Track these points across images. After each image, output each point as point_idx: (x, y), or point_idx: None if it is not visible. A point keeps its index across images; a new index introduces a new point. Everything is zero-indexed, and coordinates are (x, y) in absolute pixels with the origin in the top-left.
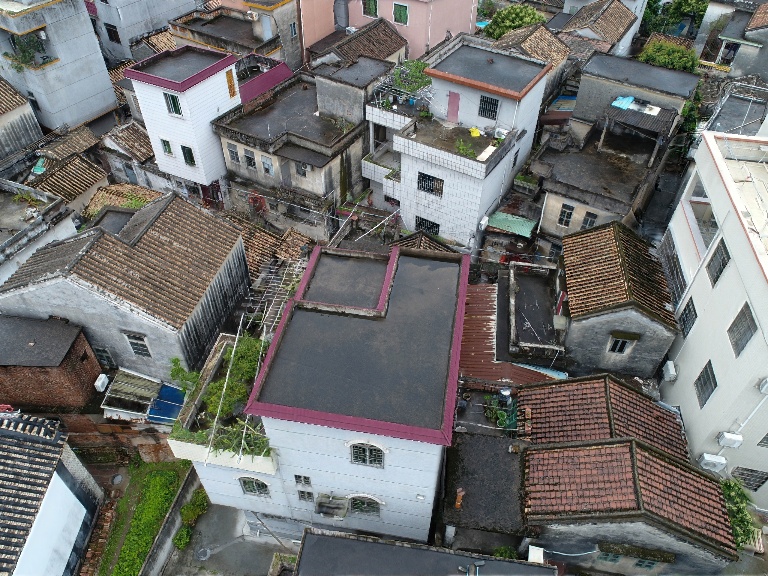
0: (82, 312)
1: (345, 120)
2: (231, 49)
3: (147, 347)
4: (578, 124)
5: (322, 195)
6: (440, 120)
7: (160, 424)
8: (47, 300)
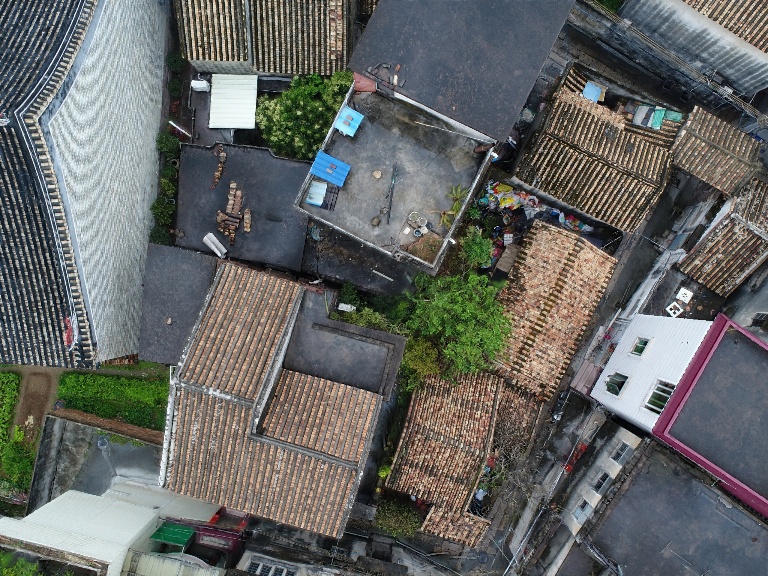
0: None
1: None
2: None
3: None
4: None
5: (546, 575)
6: None
7: None
8: None
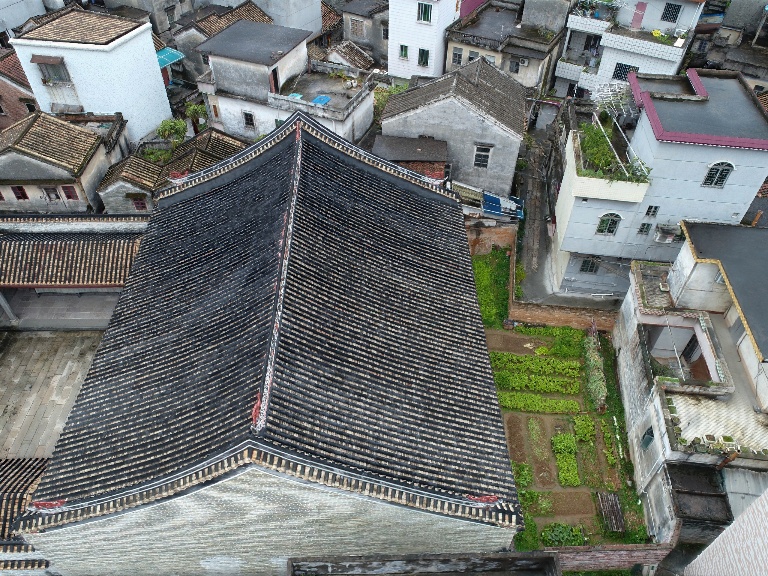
0: (450, 129)
1: (547, 29)
2: None
3: (488, 157)
4: (727, 31)
5: None
6: (625, 27)
7: (488, 218)
8: (426, 121)
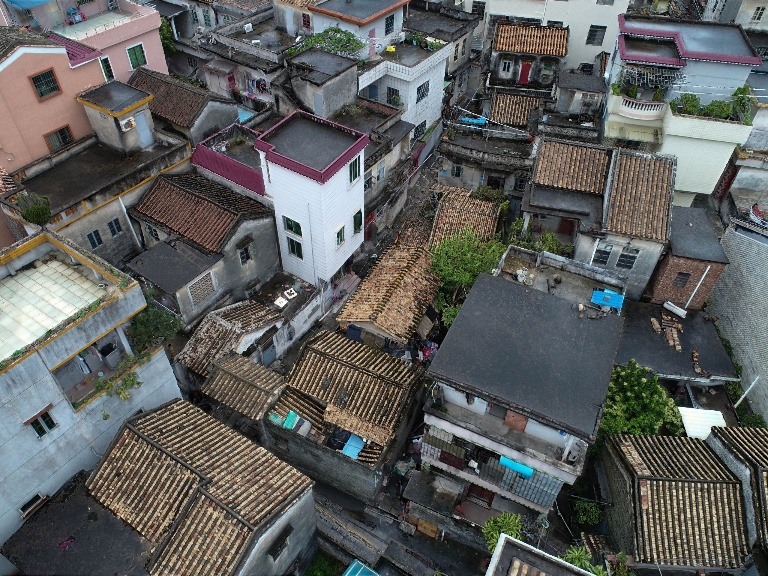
0: None
1: (347, 106)
2: (156, 170)
3: None
4: None
5: (395, 164)
6: (368, 60)
7: None
8: None
